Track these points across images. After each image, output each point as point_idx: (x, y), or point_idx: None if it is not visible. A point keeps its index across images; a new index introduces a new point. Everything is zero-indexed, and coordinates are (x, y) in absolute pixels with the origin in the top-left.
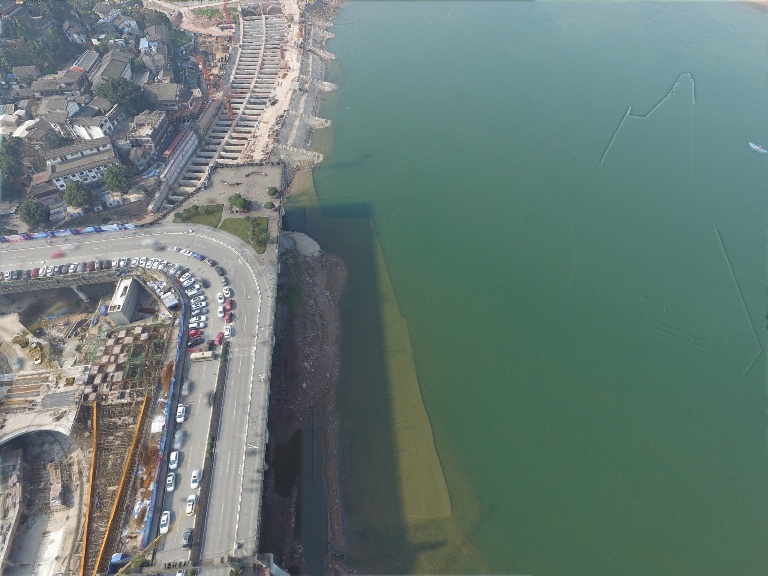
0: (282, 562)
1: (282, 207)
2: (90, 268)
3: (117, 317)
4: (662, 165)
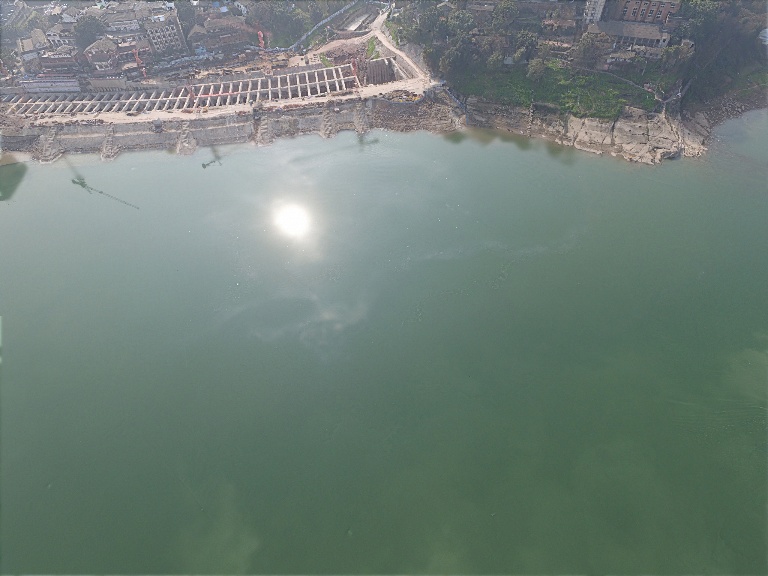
0: None
1: None
2: None
3: None
4: None
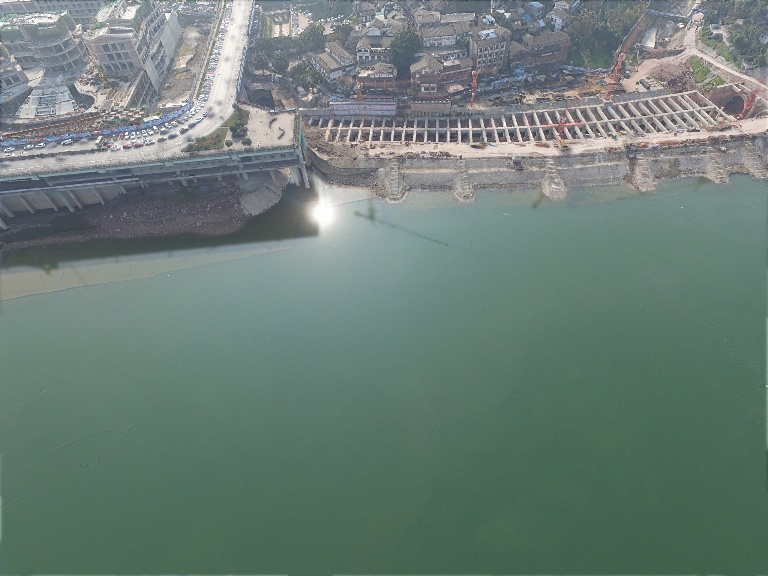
0: (14, 224)
1: (234, 153)
2: None
3: None
4: (47, 431)
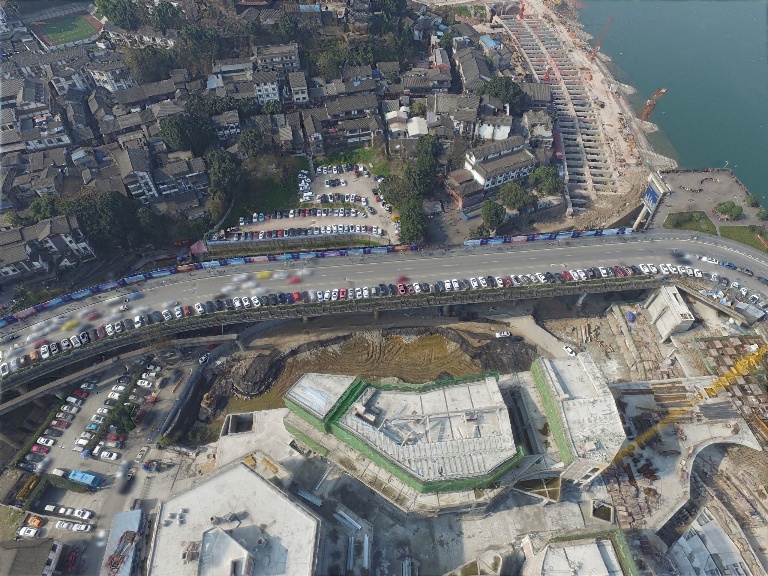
0: None
1: None
2: (624, 273)
3: (683, 325)
4: None
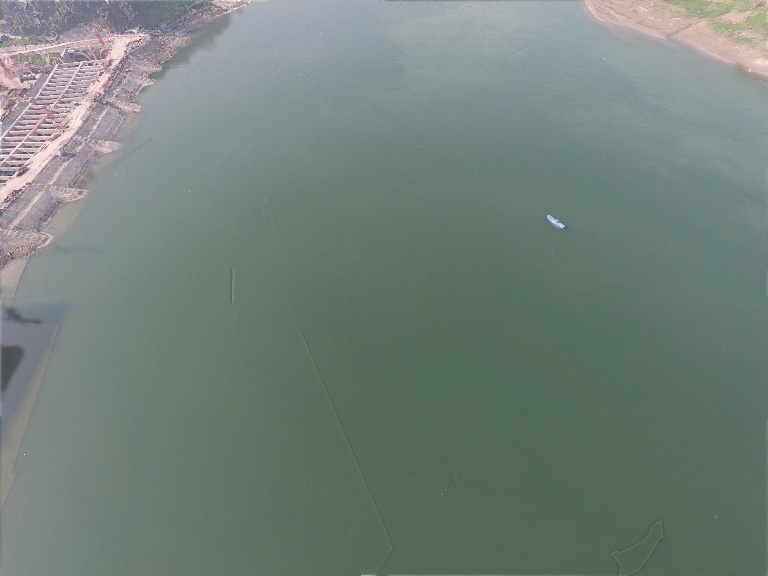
0: None
1: None
2: None
3: None
4: (269, 302)
